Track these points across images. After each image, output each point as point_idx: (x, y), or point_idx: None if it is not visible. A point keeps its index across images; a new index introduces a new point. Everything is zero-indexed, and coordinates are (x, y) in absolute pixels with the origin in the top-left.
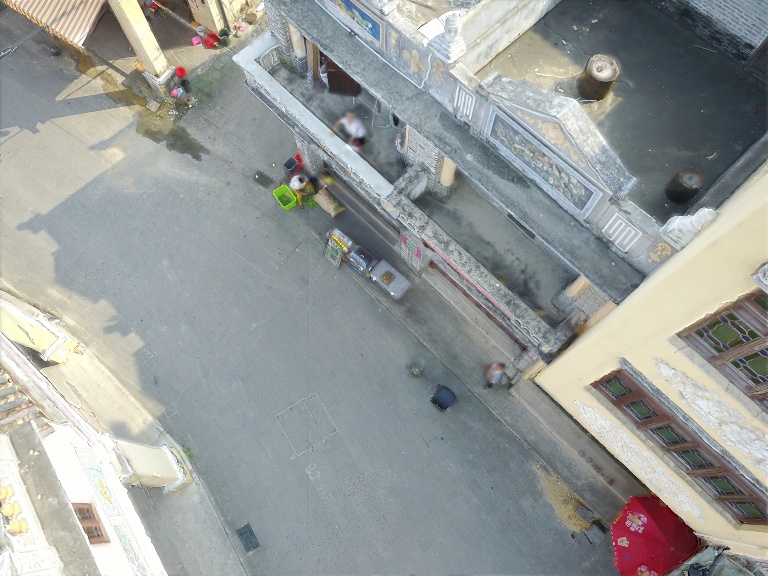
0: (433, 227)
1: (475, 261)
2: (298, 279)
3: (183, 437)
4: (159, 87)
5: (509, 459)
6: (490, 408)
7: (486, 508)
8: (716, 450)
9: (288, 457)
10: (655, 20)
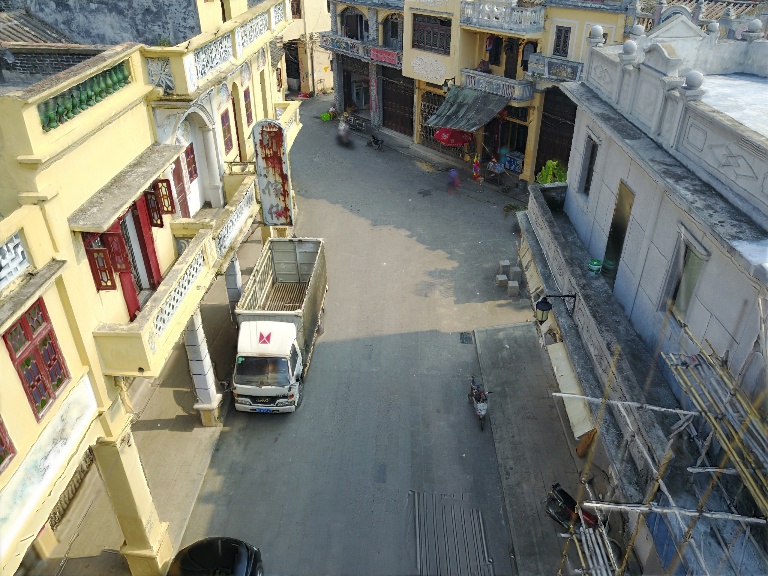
0: None
1: None
2: None
3: None
4: None
5: None
6: None
7: None
8: (429, 11)
9: None
10: None
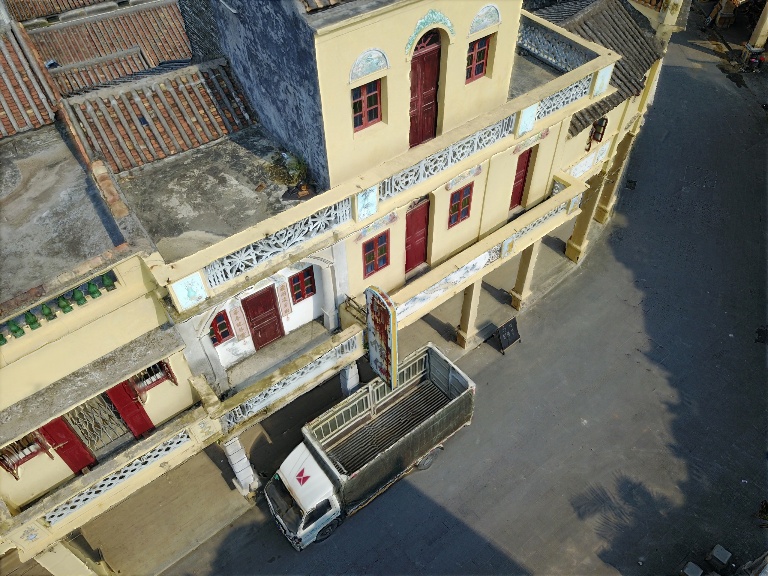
0: None
1: None
2: (749, 141)
3: (635, 145)
4: (747, 54)
5: None
6: None
7: None
8: None
9: (679, 178)
10: None
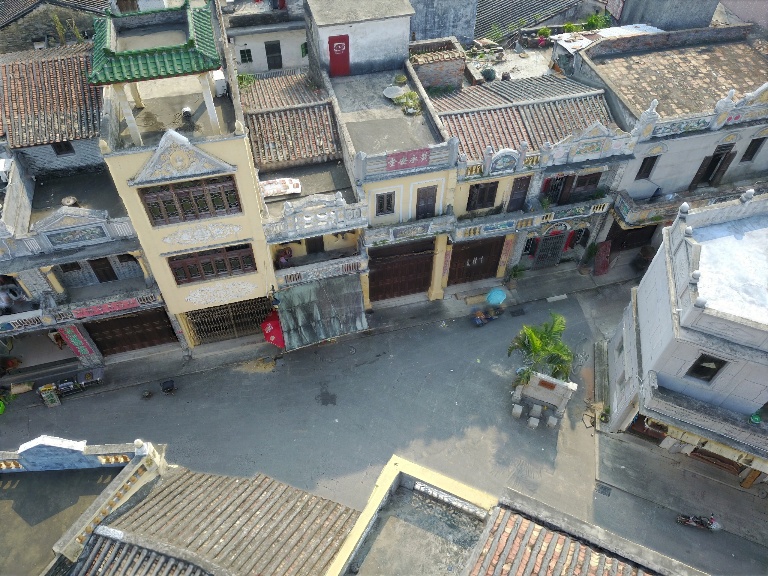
0: (73, 305)
1: (101, 298)
2: (46, 428)
3: None
4: None
5: (222, 378)
6: (193, 372)
7: (234, 401)
8: (207, 248)
9: None
10: (73, 179)
